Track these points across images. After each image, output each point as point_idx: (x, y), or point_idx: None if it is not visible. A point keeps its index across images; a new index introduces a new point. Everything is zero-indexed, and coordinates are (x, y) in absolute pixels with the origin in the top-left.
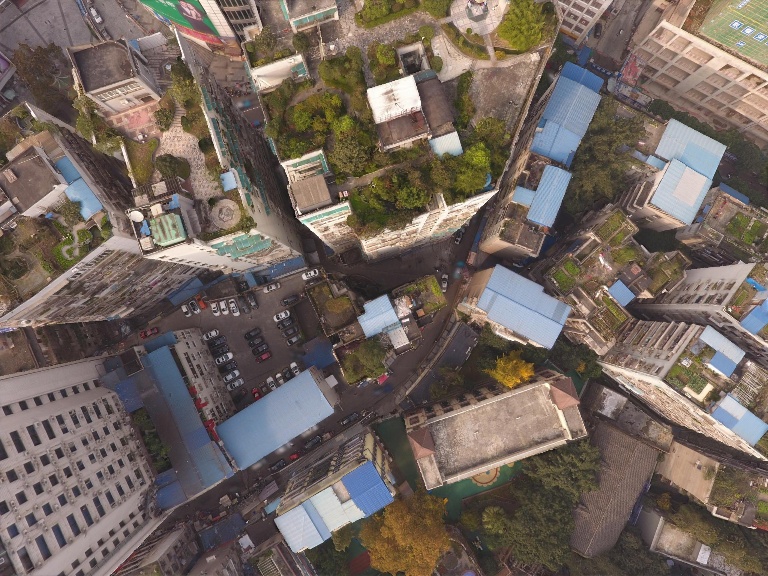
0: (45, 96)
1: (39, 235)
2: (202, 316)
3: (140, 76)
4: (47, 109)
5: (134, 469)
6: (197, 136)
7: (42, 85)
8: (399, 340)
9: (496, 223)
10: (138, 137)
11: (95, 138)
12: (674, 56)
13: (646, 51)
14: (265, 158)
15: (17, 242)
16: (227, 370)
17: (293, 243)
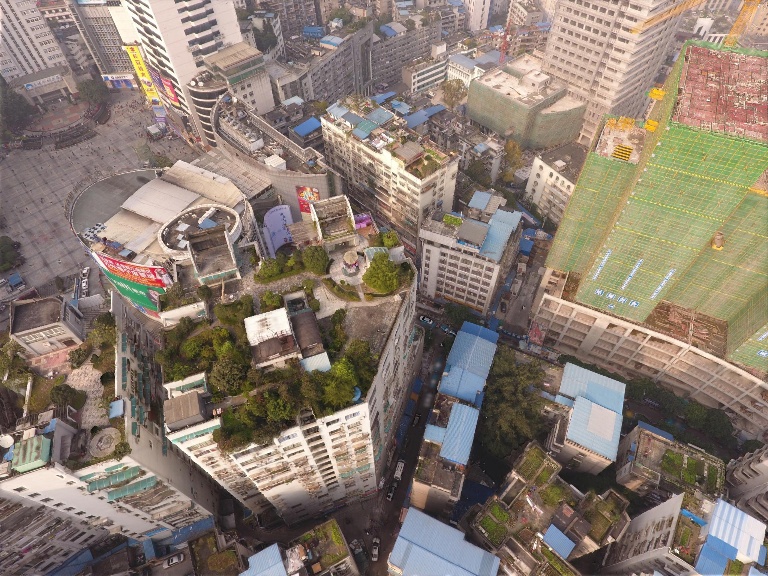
0: None
1: None
2: None
3: (65, 322)
4: None
5: None
6: (103, 372)
7: None
8: None
9: None
10: (48, 374)
11: (8, 375)
12: (566, 320)
13: (543, 318)
14: None
15: None
16: None
17: (200, 497)
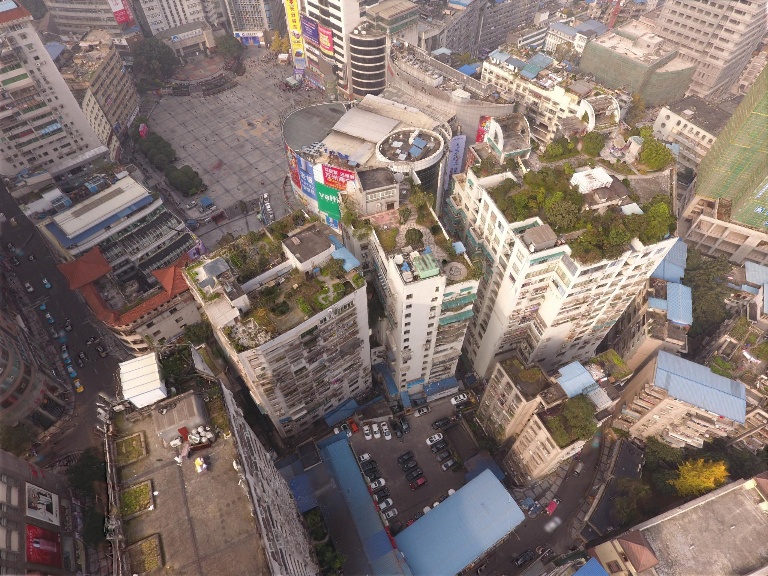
0: None
1: (300, 288)
2: (352, 440)
3: None
4: None
5: None
6: (427, 226)
7: None
8: (601, 400)
9: (633, 337)
10: (384, 227)
11: (353, 227)
12: (715, 241)
13: (691, 241)
14: None
15: (289, 287)
16: (380, 498)
17: None
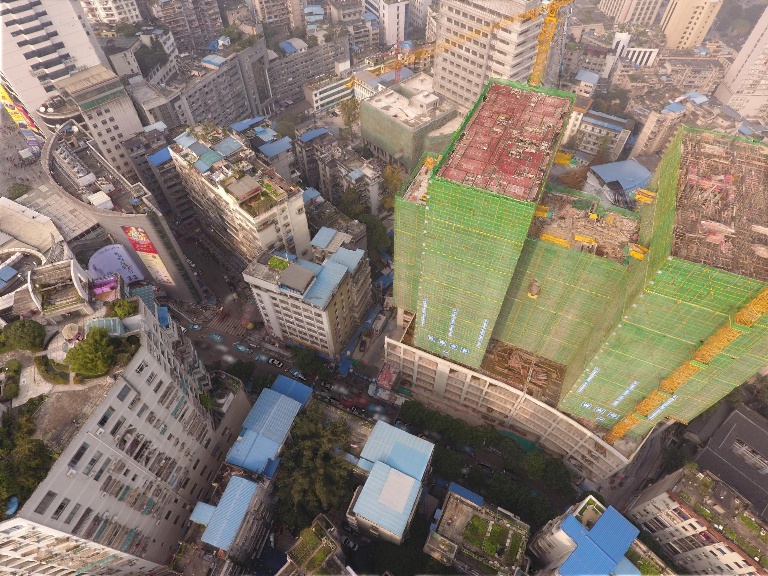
0: None
1: None
2: None
3: None
4: None
5: None
6: None
7: None
8: None
9: None
10: None
11: None
12: None
13: (393, 360)
14: None
15: None
16: None
17: None
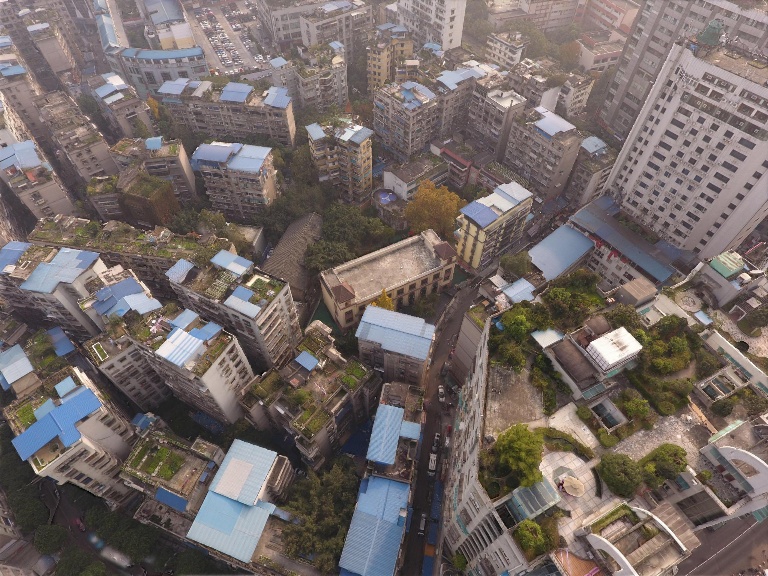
0: None
1: None
2: None
3: None
4: None
5: (639, 205)
6: (754, 355)
7: None
8: (498, 280)
9: None
10: None
11: None
12: None
13: None
14: None
15: None
16: None
17: None
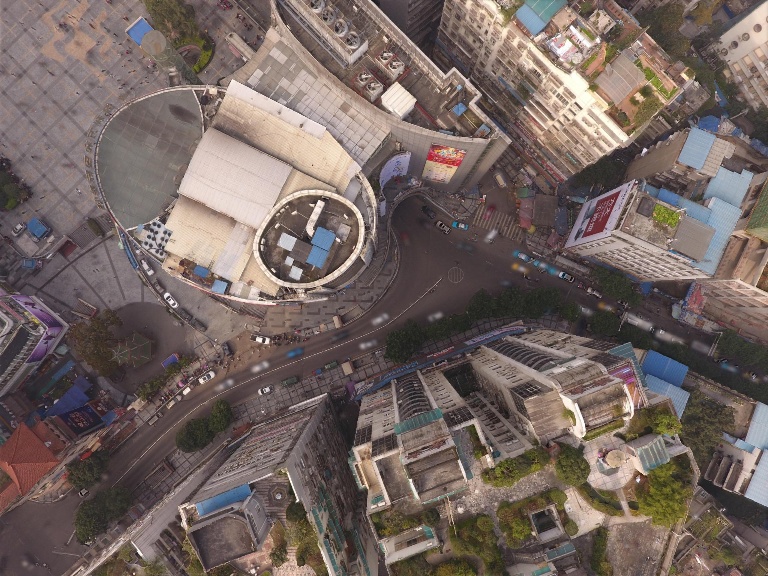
0: (103, 366)
1: None
2: None
3: None
4: (104, 375)
5: None
6: (312, 567)
7: (100, 358)
8: None
9: None
10: (251, 572)
11: None
12: (743, 295)
13: None
14: (334, 425)
15: None
16: None
17: None
